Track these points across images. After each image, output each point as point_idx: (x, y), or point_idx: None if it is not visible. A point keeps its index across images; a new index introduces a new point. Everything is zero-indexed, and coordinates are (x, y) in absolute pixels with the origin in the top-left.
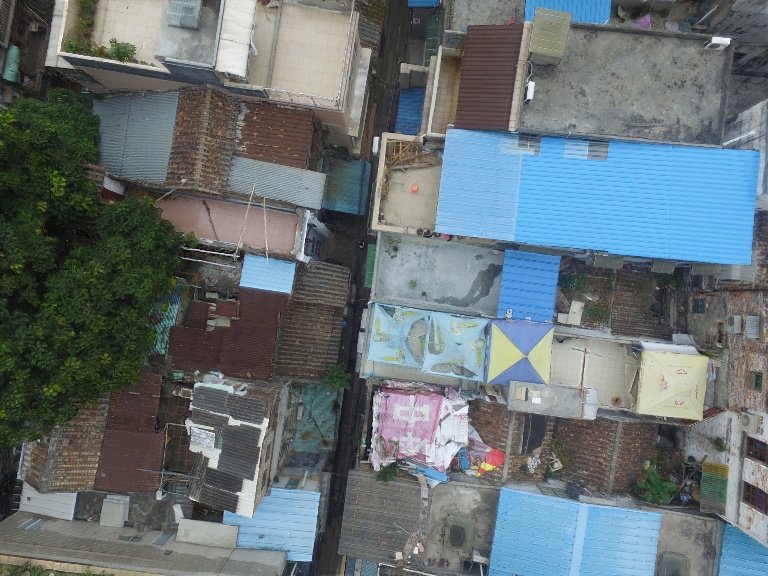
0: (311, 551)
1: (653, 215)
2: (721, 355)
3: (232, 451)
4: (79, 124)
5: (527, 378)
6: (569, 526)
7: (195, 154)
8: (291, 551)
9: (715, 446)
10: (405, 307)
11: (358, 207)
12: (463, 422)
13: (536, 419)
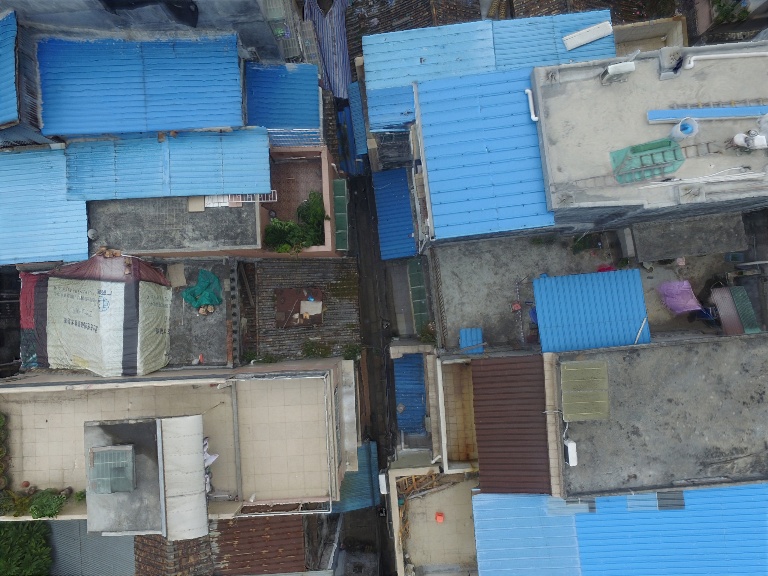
0: None
1: (760, 574)
2: None
3: None
4: (21, 530)
5: None
6: None
7: None
8: None
9: None
10: None
11: (371, 499)
12: None
13: None
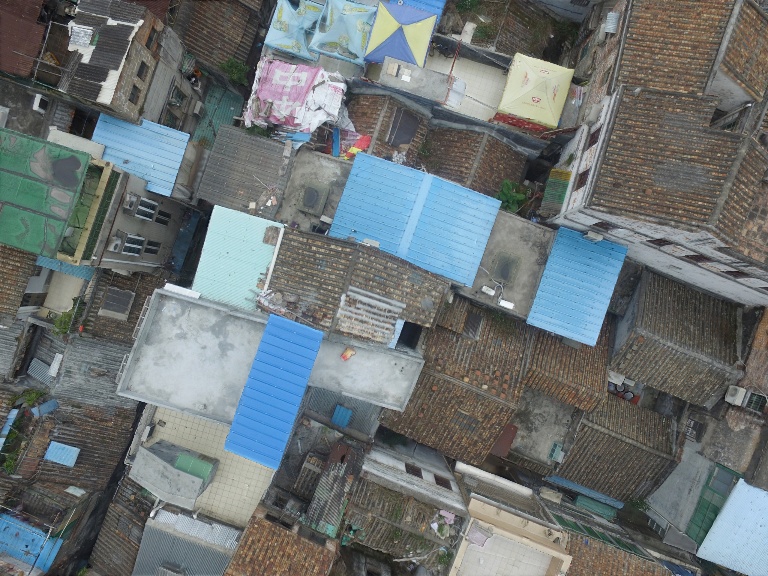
0: (171, 187)
1: None
2: (589, 80)
3: (105, 46)
4: None
5: (402, 57)
6: (412, 192)
7: None
8: (152, 182)
9: (567, 163)
10: (309, 0)
11: None
12: (337, 96)
13: (408, 116)
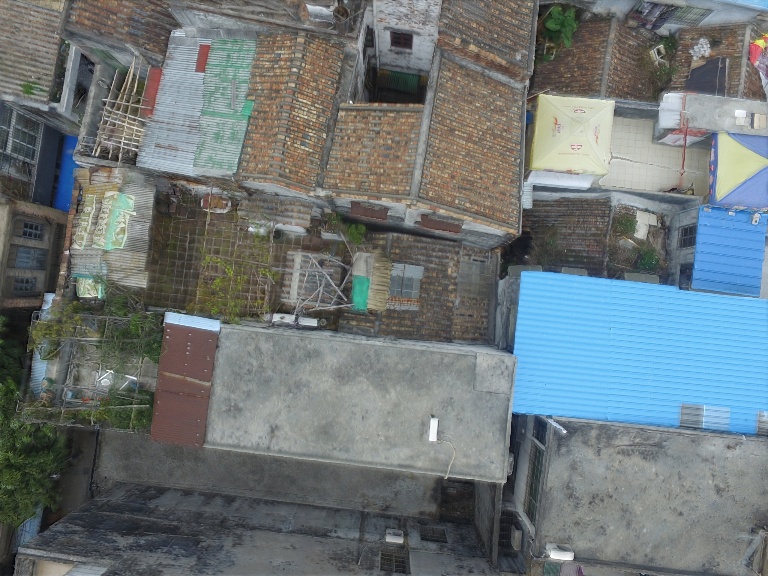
0: None
1: (629, 333)
2: None
3: None
4: None
5: (751, 140)
6: None
7: None
8: None
9: None
10: None
11: None
12: None
13: None
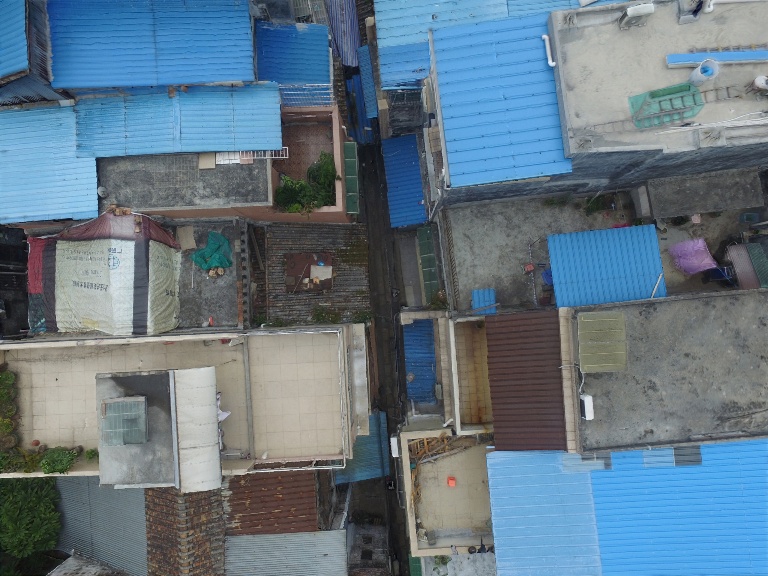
0: None
1: None
2: None
3: None
4: (30, 494)
5: None
6: None
7: (177, 554)
8: None
9: None
10: None
11: (381, 469)
12: None
13: None
